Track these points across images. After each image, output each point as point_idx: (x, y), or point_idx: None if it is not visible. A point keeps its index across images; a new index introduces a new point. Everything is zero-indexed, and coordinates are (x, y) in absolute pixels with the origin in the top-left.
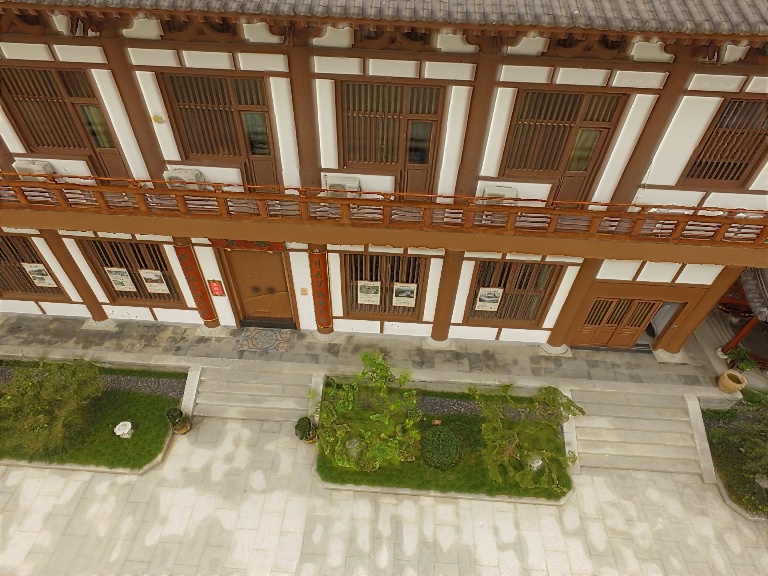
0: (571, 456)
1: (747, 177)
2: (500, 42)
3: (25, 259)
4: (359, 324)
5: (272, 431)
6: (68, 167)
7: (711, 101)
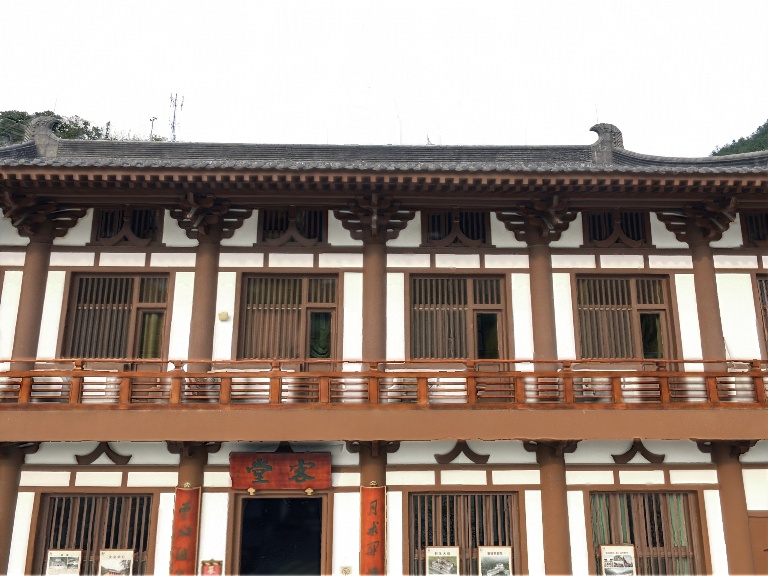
0: None
1: None
2: (548, 222)
3: None
4: None
5: None
6: None
7: (740, 277)
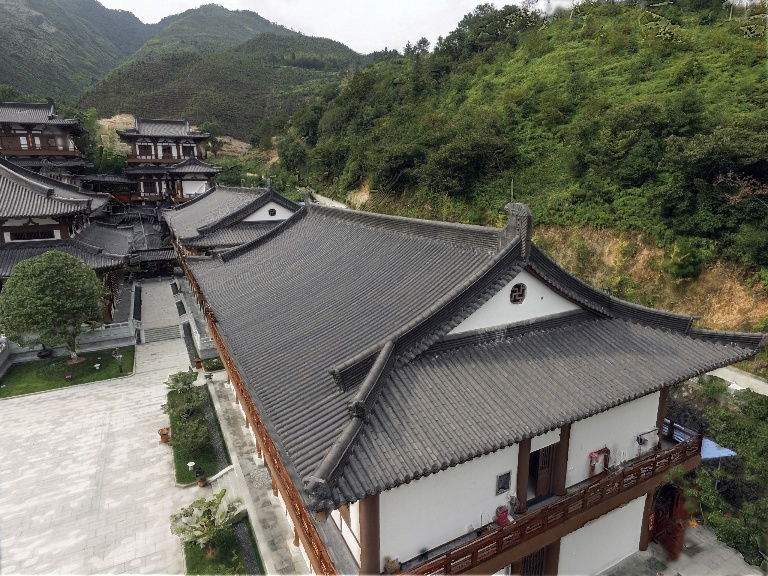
0: None
1: None
2: None
3: None
4: None
5: None
6: None
7: None
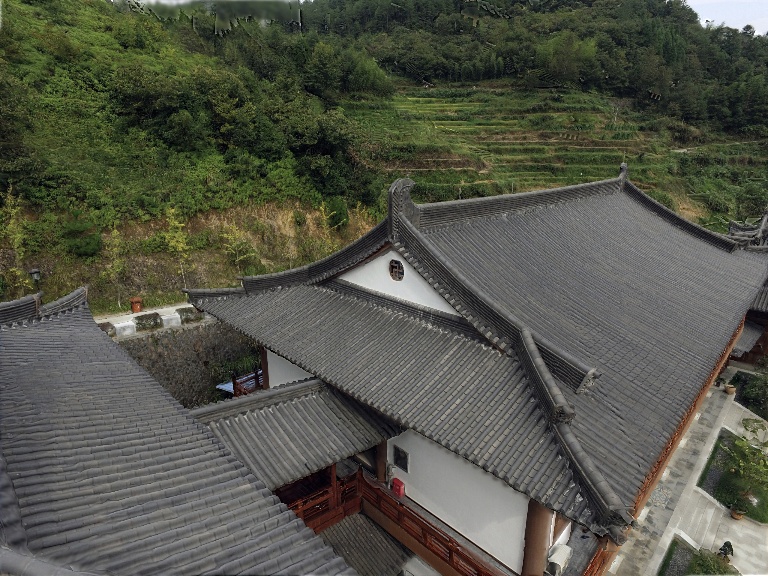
0: None
1: None
2: None
3: None
4: None
5: (727, 529)
6: None
7: None
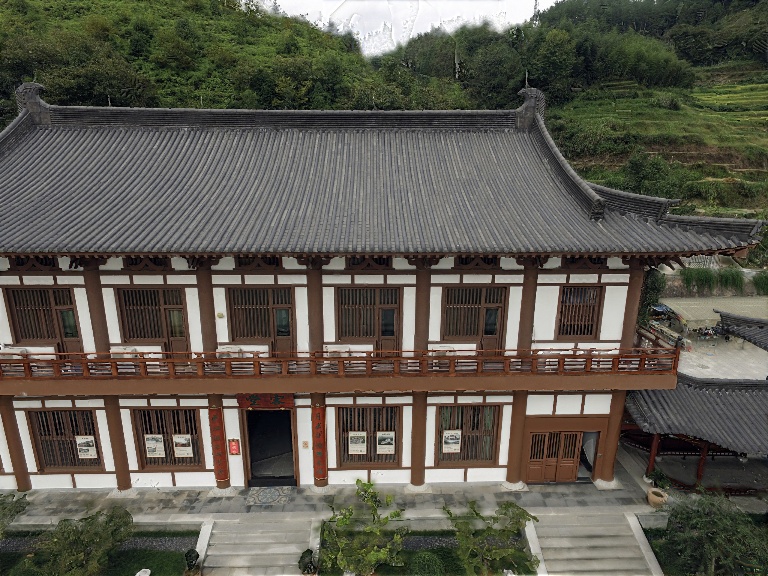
0: (535, 559)
1: (595, 332)
2: (426, 262)
3: (80, 432)
4: (350, 475)
5: (276, 575)
6: (147, 351)
7: (553, 288)
